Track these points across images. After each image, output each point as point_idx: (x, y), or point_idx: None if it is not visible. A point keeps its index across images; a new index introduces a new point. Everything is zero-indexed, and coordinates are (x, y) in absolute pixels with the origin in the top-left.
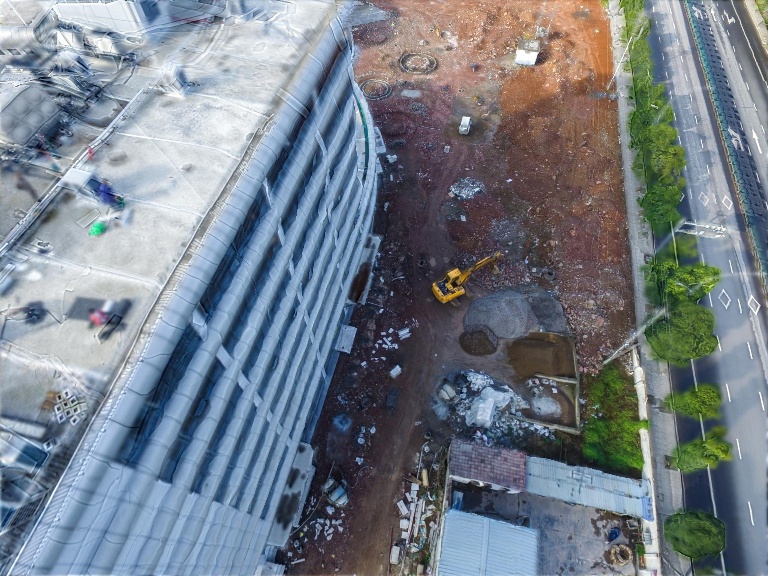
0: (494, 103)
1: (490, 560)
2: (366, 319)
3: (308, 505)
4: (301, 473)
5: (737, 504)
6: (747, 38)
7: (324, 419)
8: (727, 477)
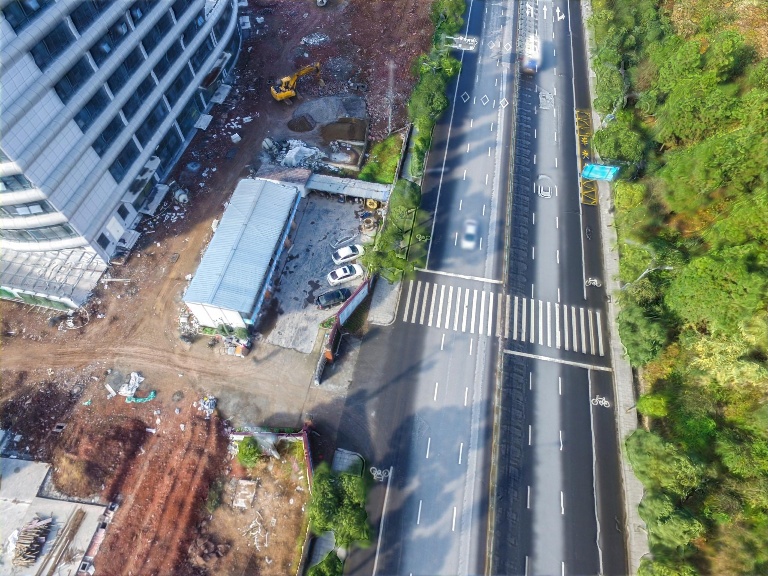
0: None
1: (261, 198)
2: (221, 112)
3: (161, 206)
4: (150, 170)
5: (453, 200)
6: None
7: (180, 164)
8: (451, 188)
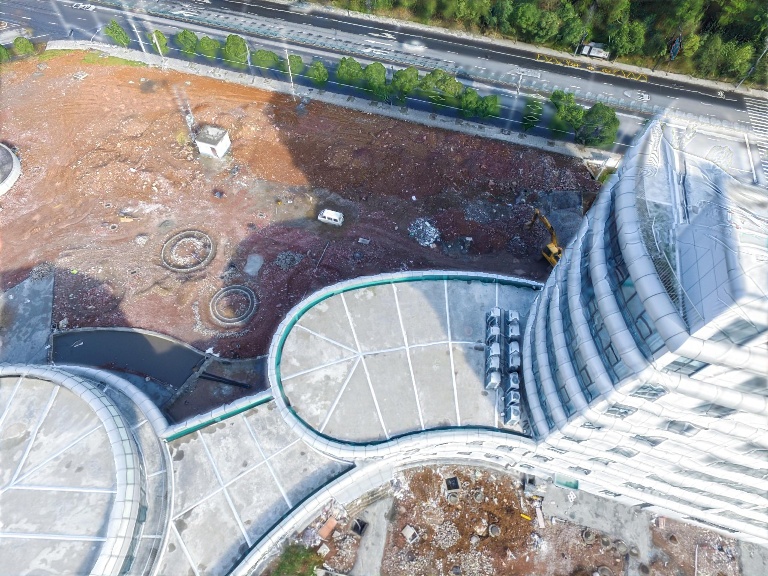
0: (291, 189)
1: None
2: None
3: None
4: None
5: None
6: (238, 2)
7: None
8: None
